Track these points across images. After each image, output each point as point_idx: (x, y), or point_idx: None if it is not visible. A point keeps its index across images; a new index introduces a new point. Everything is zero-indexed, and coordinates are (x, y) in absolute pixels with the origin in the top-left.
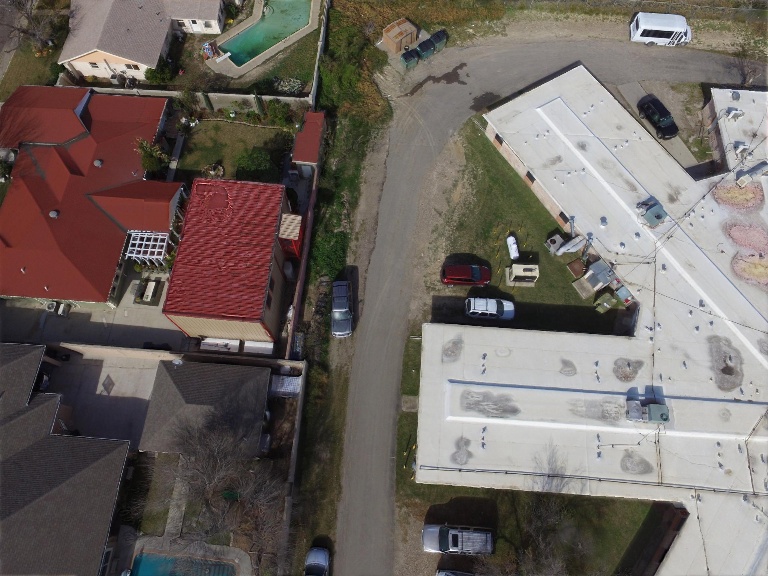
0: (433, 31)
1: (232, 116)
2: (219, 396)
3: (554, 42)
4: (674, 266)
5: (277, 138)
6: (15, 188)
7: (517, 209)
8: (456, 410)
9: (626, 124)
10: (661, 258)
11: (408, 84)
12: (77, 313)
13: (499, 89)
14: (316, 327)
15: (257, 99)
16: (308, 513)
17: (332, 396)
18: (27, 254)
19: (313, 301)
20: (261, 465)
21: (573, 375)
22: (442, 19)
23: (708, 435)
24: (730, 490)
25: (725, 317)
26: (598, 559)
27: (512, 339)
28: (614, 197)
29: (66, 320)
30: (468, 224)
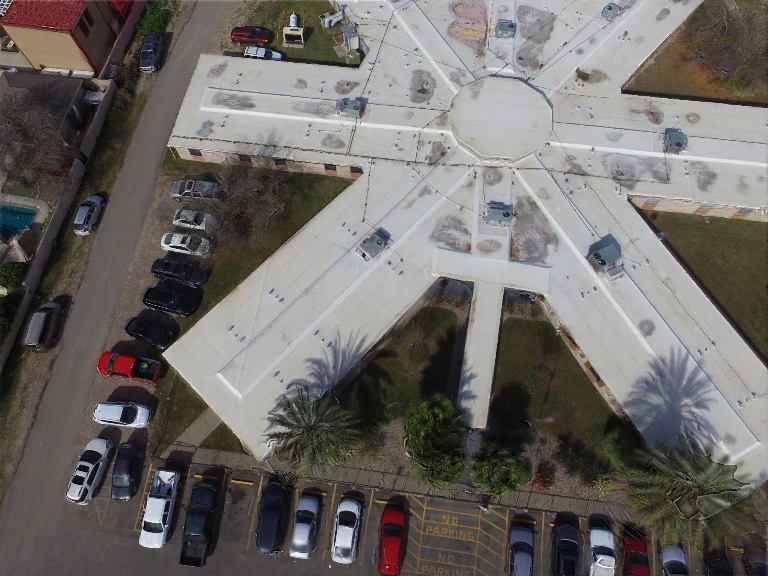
0: None
1: None
2: (35, 86)
3: None
4: (403, 27)
5: None
6: None
7: None
8: (208, 103)
9: None
10: (395, 22)
11: None
12: None
13: None
14: (129, 65)
15: None
16: (96, 178)
17: (132, 110)
18: None
19: (133, 51)
20: (69, 149)
21: (303, 89)
22: None
23: (392, 127)
24: (398, 160)
25: (430, 58)
26: (301, 213)
27: (264, 66)
28: None
29: None
30: (265, 8)
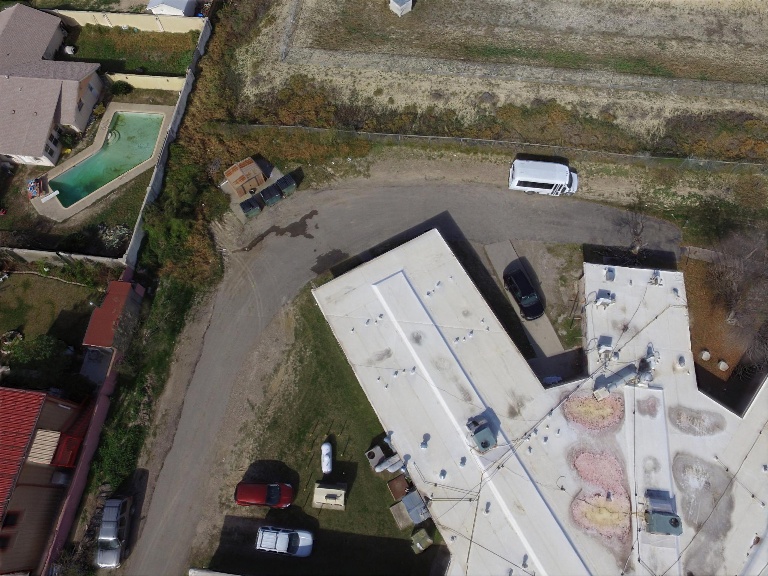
0: (287, 169)
1: (46, 270)
2: None
3: (422, 186)
4: (500, 506)
5: (90, 300)
6: None
7: (342, 404)
8: None
9: (474, 308)
10: (487, 494)
11: (247, 236)
12: None
13: (348, 246)
14: (83, 553)
15: None
16: None
17: None
18: None
19: (89, 516)
20: None
21: None
22: (297, 156)
23: None
24: None
25: None
26: None
27: None
28: (444, 407)
29: None
30: (283, 422)
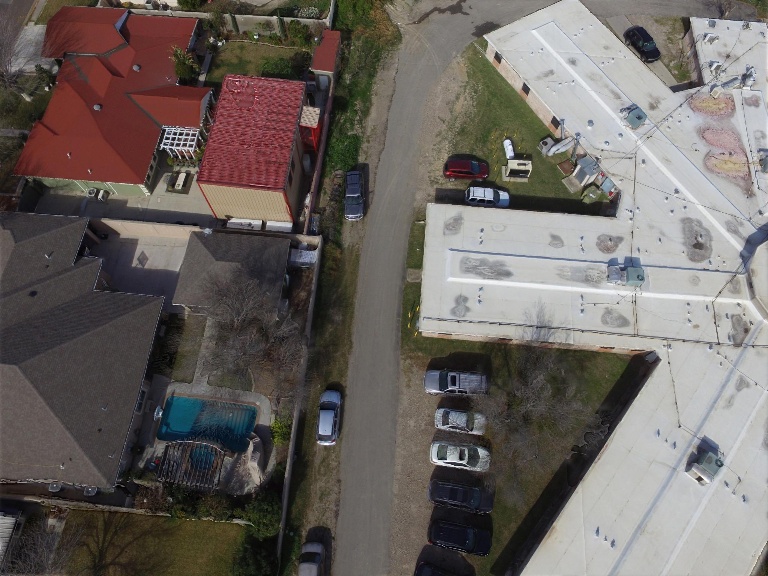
0: None
1: (256, 38)
2: (245, 256)
3: None
4: (653, 161)
5: (297, 57)
6: (61, 90)
7: (513, 118)
8: (456, 273)
9: (612, 45)
10: (641, 154)
11: (416, 14)
12: (115, 200)
13: (499, 19)
14: (331, 211)
15: (280, 19)
16: (322, 364)
17: (344, 270)
18: (73, 141)
19: (328, 191)
20: (280, 325)
21: (560, 247)
22: None
23: (679, 297)
24: (698, 341)
25: (697, 202)
26: None
27: (507, 217)
28: (600, 104)
29: (105, 205)
30: (469, 130)
